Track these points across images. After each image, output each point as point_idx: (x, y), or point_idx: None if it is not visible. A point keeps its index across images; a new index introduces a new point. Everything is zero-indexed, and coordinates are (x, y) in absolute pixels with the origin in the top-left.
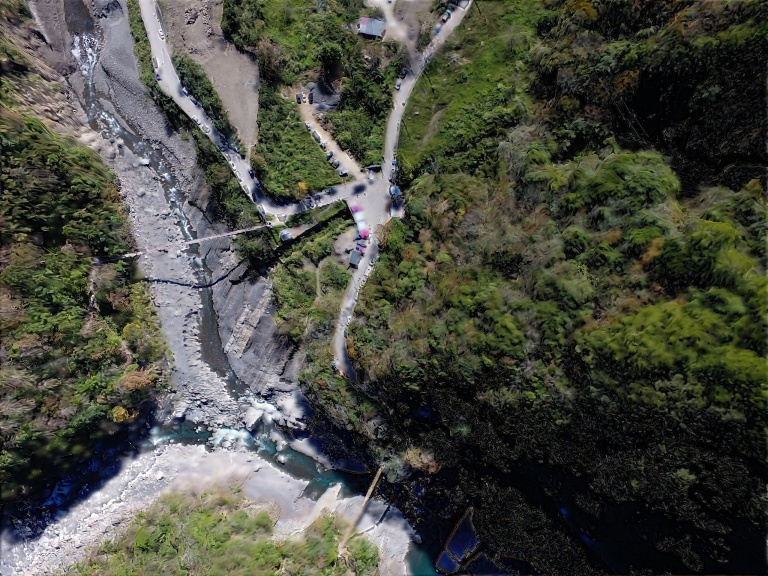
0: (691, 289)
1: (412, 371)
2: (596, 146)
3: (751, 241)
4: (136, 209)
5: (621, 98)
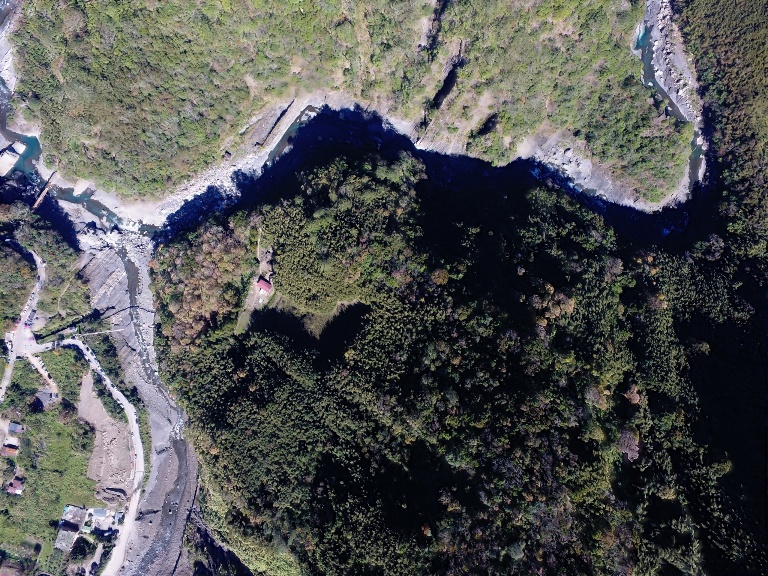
0: None
1: None
2: None
3: None
4: None
5: None
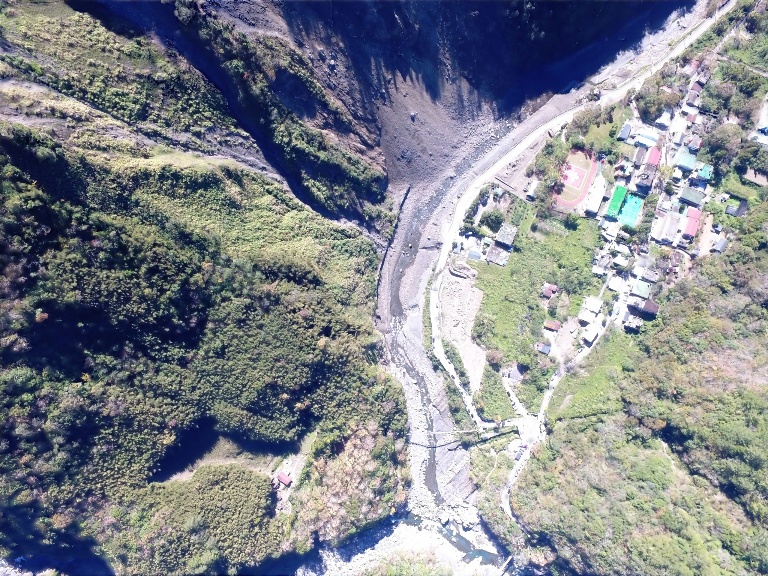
0: (672, 534)
1: (549, 526)
2: (643, 441)
3: (697, 516)
4: (407, 405)
5: (657, 429)
